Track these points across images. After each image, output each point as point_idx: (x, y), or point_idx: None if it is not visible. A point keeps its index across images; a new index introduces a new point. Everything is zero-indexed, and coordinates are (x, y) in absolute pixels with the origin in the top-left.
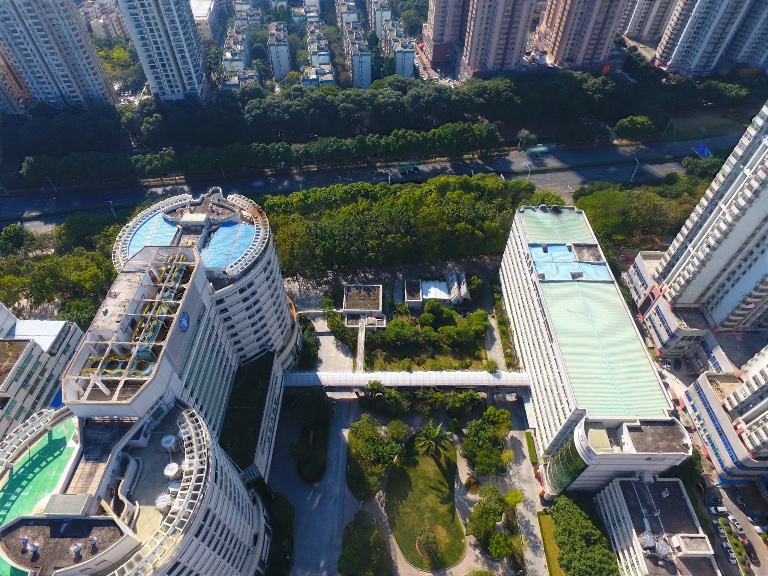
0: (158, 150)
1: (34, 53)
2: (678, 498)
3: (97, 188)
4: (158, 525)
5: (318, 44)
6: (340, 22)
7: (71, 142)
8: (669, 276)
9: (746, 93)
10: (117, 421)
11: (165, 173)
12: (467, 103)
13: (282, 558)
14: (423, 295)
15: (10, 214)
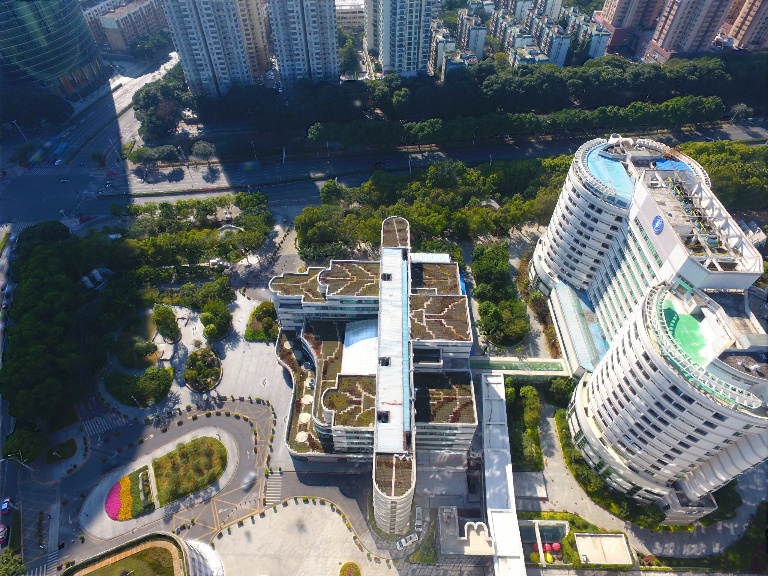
0: None
1: (301, 32)
2: None
3: (362, 154)
4: None
5: (520, 28)
6: (512, 10)
7: (332, 113)
8: None
9: None
10: (725, 293)
11: (431, 139)
12: (680, 80)
13: None
14: None
15: (298, 175)
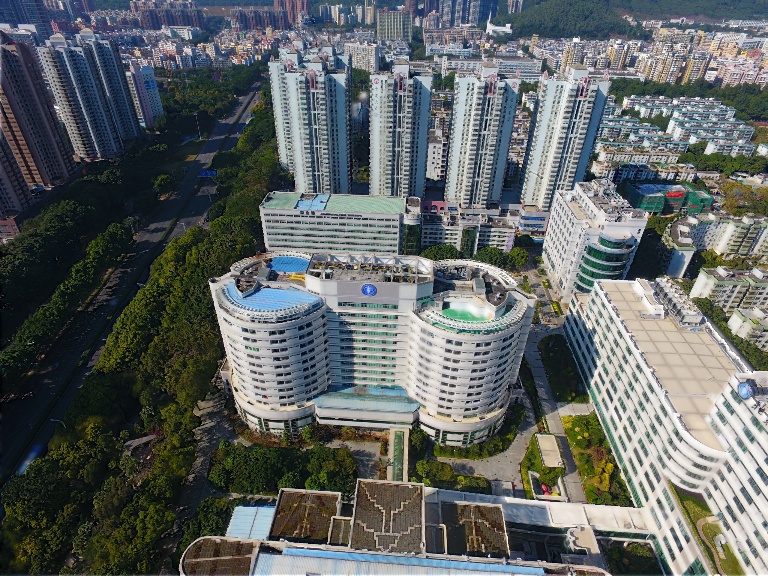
0: None
1: None
2: (429, 216)
3: None
4: None
5: None
6: None
7: None
8: None
9: (167, 146)
10: None
11: None
12: (63, 231)
13: None
14: None
15: None
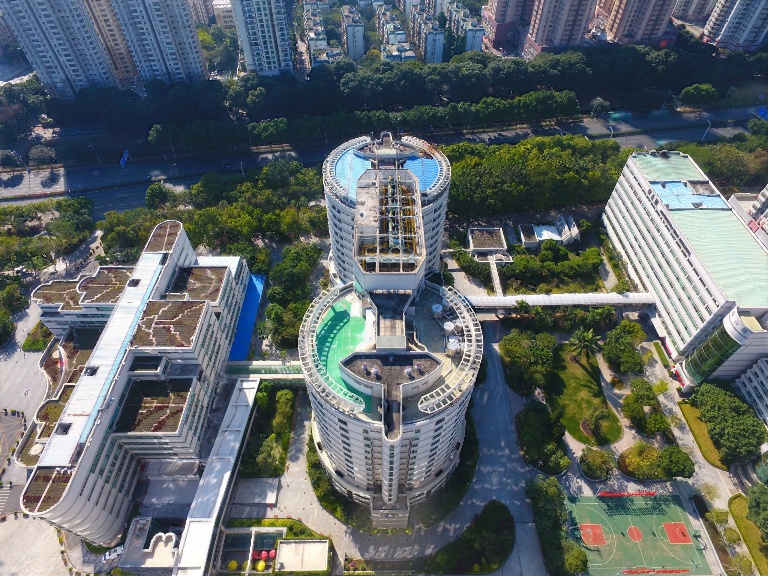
0: (258, 122)
1: (149, 32)
2: None
3: (212, 155)
4: (450, 364)
5: (394, 24)
6: (402, 6)
7: (184, 114)
8: (767, 210)
9: None
10: (394, 293)
11: (277, 139)
12: (542, 75)
13: (472, 437)
14: (538, 237)
15: (139, 178)
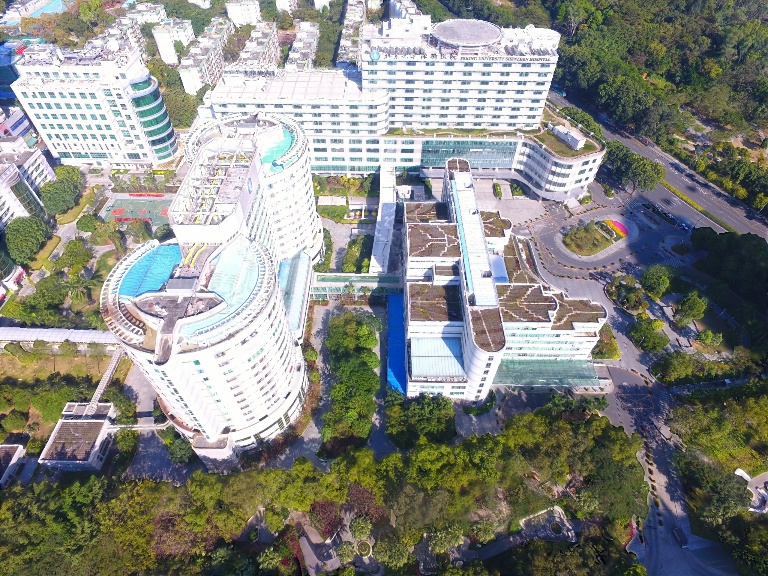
0: None
1: None
2: None
3: None
4: None
5: None
6: None
7: None
8: None
9: None
10: None
11: None
12: None
13: None
14: None
15: None
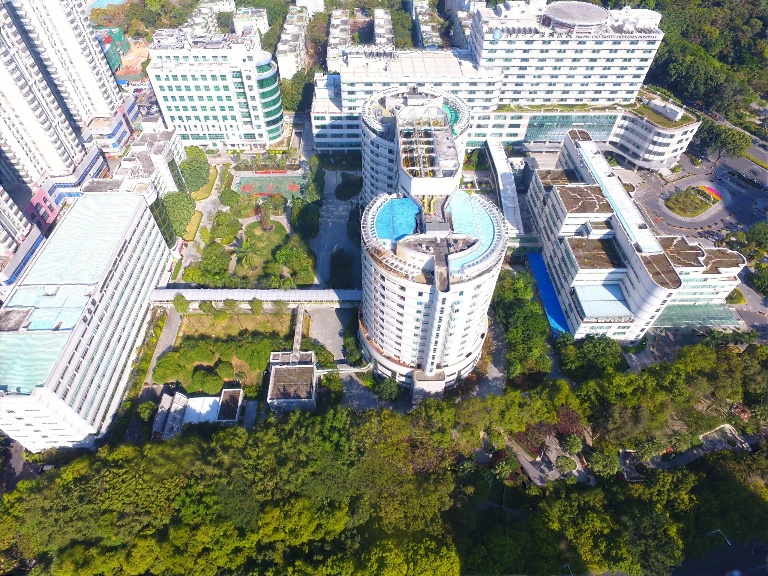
0: None
1: None
2: None
3: None
4: None
5: None
6: None
7: None
8: None
9: None
10: None
11: None
12: None
13: (352, 218)
14: None
15: None
